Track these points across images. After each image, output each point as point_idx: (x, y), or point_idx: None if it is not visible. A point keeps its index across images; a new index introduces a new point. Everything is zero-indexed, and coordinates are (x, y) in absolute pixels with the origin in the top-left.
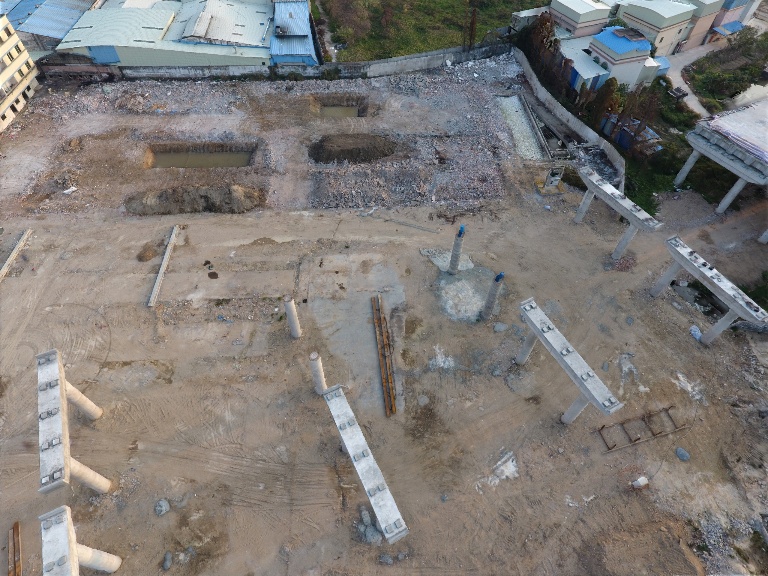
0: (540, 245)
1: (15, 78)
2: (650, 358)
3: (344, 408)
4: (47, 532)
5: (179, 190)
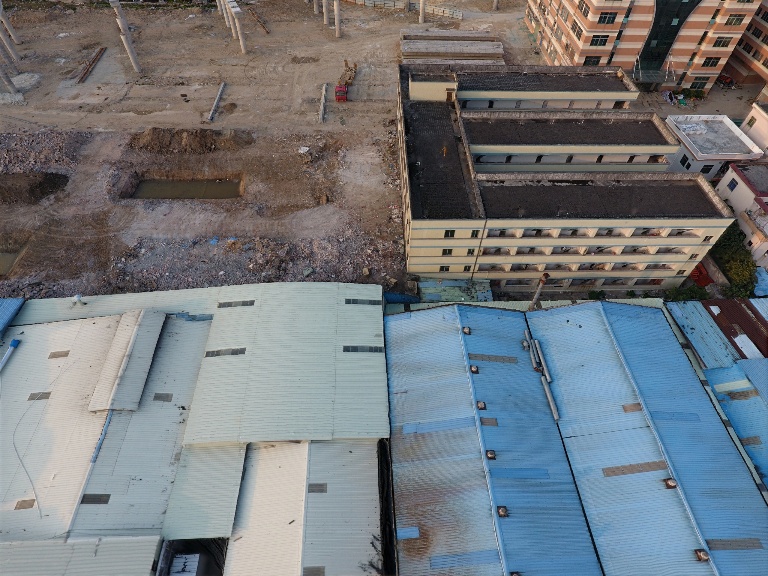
0: None
1: None
2: None
3: None
4: None
5: (199, 129)
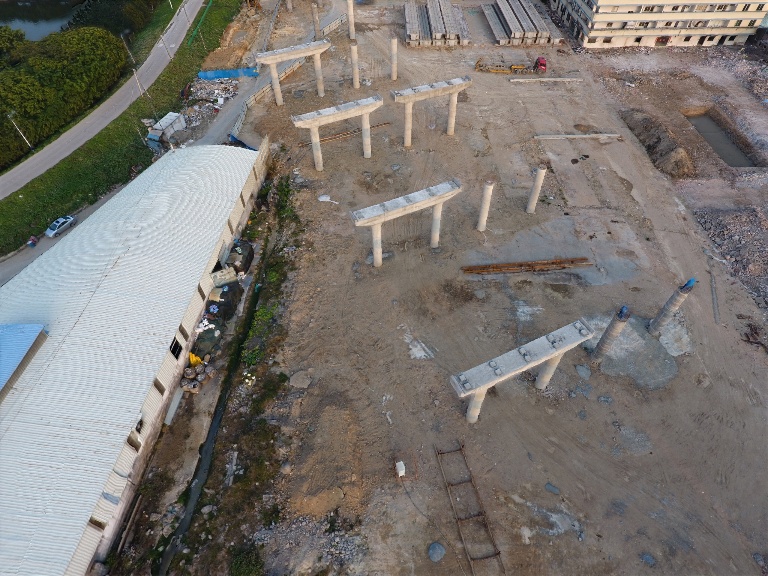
0: (763, 453)
1: (729, 23)
2: (582, 567)
3: (443, 190)
4: (371, 98)
5: (657, 123)
